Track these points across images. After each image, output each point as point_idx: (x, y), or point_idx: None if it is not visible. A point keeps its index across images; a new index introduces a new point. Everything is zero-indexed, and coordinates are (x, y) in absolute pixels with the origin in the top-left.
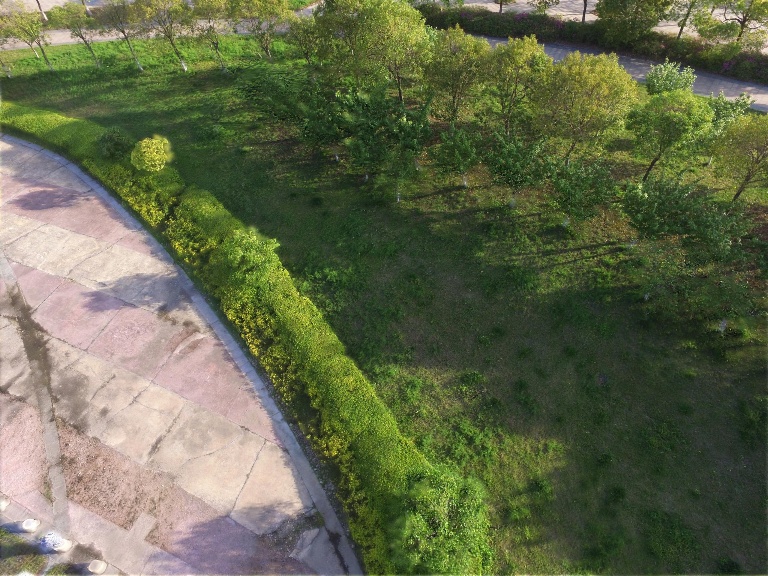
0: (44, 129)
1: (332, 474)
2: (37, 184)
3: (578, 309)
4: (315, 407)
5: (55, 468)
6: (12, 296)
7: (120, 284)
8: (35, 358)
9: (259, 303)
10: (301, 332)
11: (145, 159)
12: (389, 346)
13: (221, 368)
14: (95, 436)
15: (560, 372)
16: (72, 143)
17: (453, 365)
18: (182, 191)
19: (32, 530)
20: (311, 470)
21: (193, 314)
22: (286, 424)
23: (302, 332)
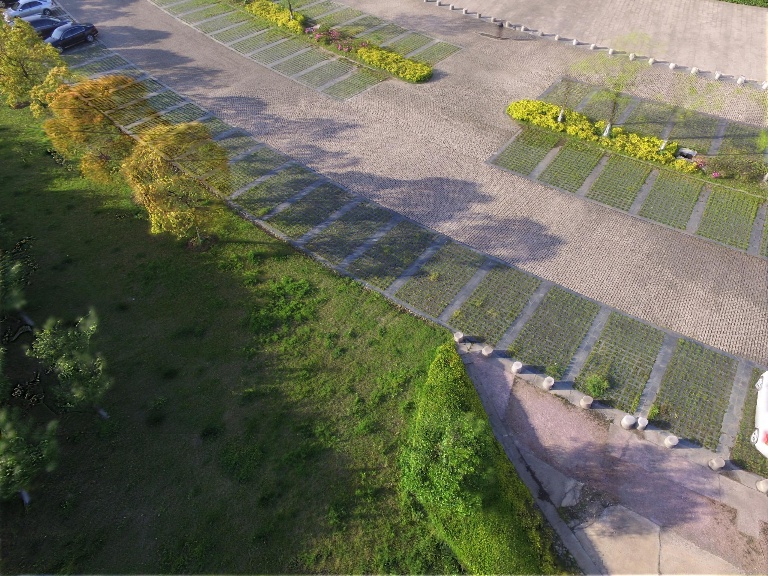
0: None
1: (561, 564)
2: None
3: None
4: None
5: None
6: None
7: None
8: None
9: None
10: None
11: None
12: None
13: None
14: None
15: None
16: None
17: None
18: None
19: None
20: (587, 573)
21: None
22: None
23: None
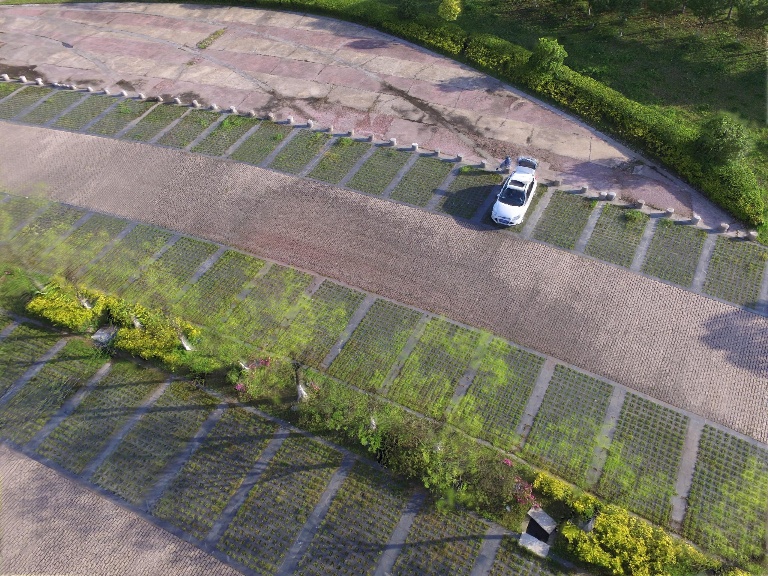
0: (343, 6)
1: (639, 147)
2: (354, 37)
3: (760, 77)
4: (618, 120)
5: (477, 148)
6: (387, 86)
7: (453, 81)
8: (427, 110)
9: (558, 81)
10: (595, 90)
11: (452, 10)
12: (648, 98)
13: (545, 113)
14: (490, 137)
15: (757, 104)
16: (369, 13)
17: (691, 104)
18: (469, 34)
19: (485, 166)
20: (625, 147)
21: (510, 92)
22: (599, 132)
23: (595, 90)
